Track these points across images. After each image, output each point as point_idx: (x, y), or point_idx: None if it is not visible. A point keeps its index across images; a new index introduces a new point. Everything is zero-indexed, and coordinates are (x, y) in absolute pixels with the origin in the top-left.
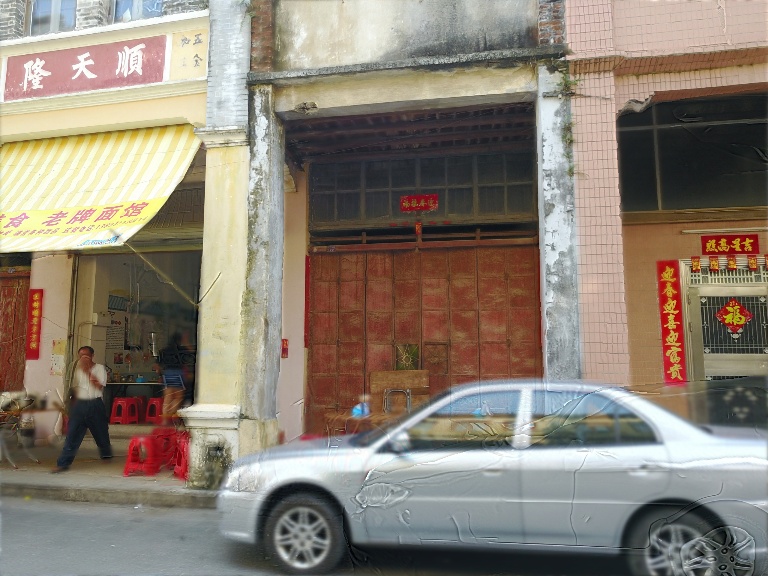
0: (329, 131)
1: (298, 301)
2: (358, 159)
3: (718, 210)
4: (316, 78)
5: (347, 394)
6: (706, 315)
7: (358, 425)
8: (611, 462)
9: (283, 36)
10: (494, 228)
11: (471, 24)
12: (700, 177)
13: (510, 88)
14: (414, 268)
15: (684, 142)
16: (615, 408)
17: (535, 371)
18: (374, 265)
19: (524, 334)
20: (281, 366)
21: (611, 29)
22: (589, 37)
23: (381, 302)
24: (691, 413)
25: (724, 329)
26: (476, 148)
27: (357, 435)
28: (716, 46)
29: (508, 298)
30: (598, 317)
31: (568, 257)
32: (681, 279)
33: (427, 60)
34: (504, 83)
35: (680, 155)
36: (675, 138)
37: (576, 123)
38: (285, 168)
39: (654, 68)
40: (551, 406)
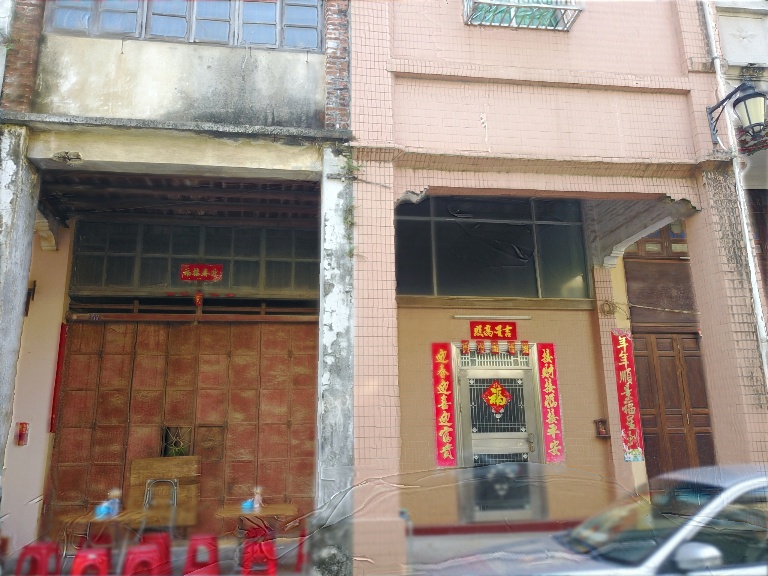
0: (100, 187)
1: (47, 376)
2: (135, 220)
3: (484, 298)
4: (82, 127)
5: (101, 487)
6: (474, 396)
7: (104, 528)
8: (367, 569)
9: (46, 76)
10: (280, 304)
11: (259, 98)
12: (469, 267)
13: (296, 165)
14: (192, 342)
15: (456, 235)
16: (375, 505)
17: (316, 454)
18: (146, 337)
19: (306, 415)
20: (16, 456)
21: (391, 124)
22: (371, 128)
23: (151, 379)
24: (448, 507)
25: (489, 409)
26: (265, 221)
27: (101, 540)
28: (479, 152)
29: (291, 377)
30: (373, 400)
31: (346, 338)
32: (453, 361)
33: (211, 126)
34: (290, 160)
35: (453, 246)
36: (449, 230)
37: (357, 206)
38: (43, 222)
39: (428, 164)
40: (323, 496)
